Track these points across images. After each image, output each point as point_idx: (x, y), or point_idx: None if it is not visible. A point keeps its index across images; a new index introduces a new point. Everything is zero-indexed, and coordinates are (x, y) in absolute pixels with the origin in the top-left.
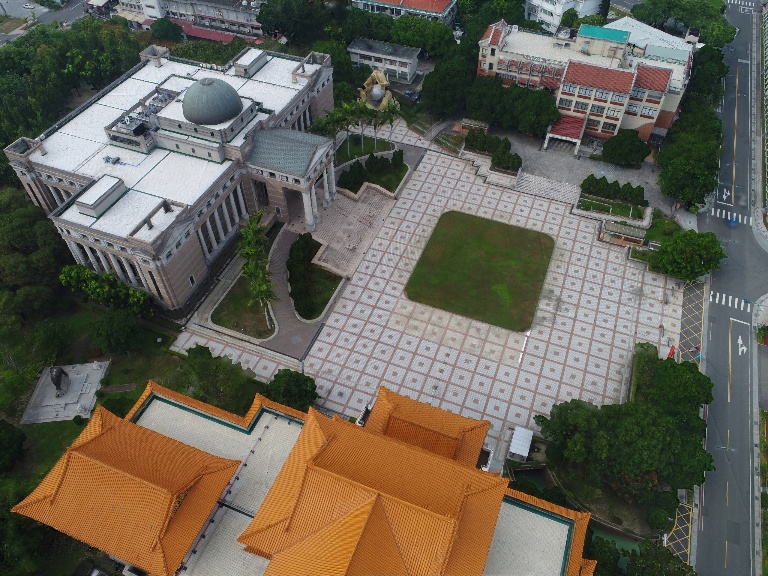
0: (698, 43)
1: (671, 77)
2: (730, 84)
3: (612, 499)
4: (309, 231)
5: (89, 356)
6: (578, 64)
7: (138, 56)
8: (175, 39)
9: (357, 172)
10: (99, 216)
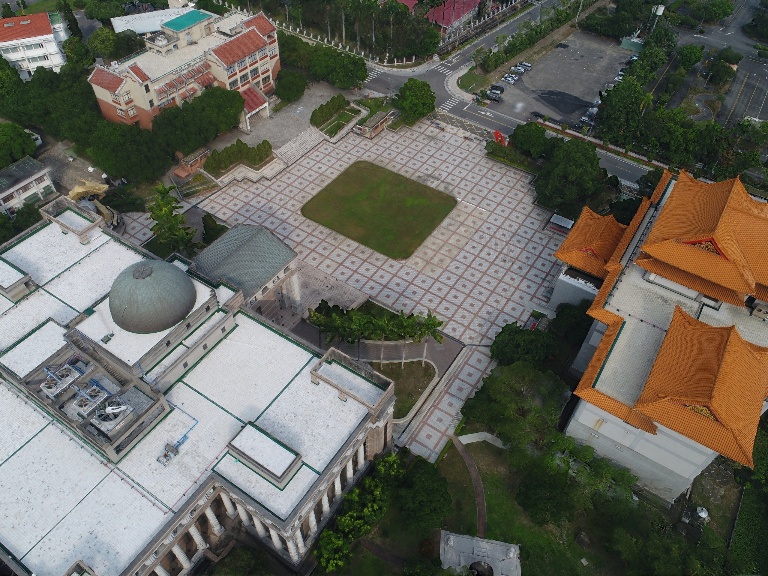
0: None
1: None
2: None
3: (594, 199)
4: (300, 311)
5: None
6: (218, 48)
7: None
8: None
9: None
10: None
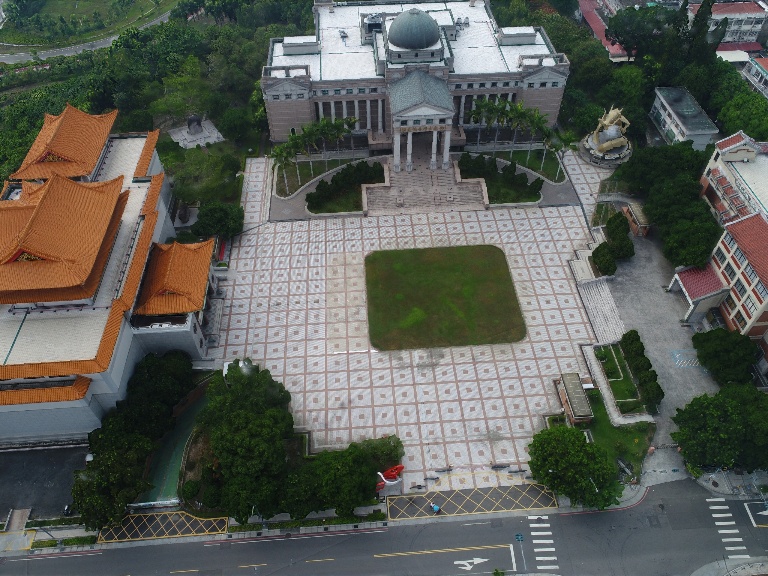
0: None
1: None
2: None
3: None
4: None
5: None
6: (763, 222)
7: (510, 4)
8: (563, 11)
9: (480, 163)
10: (286, 55)
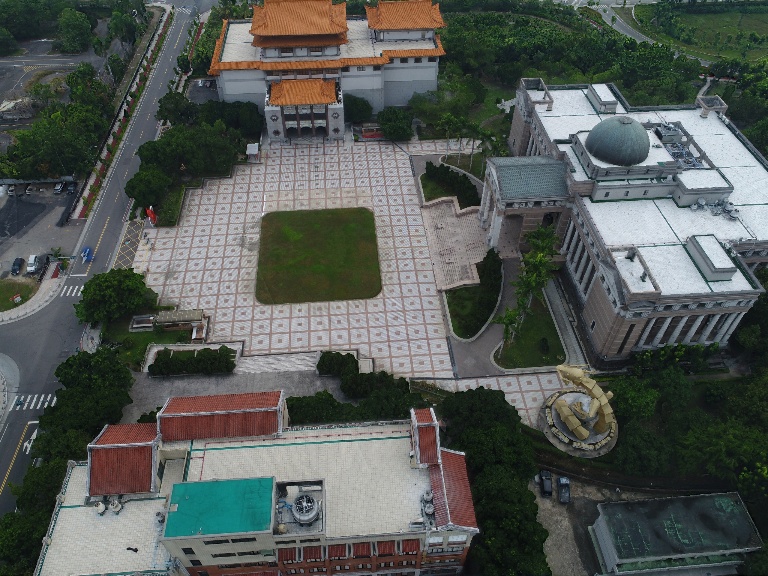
0: None
1: None
2: None
3: None
4: None
5: None
6: None
7: None
8: None
9: None
10: None
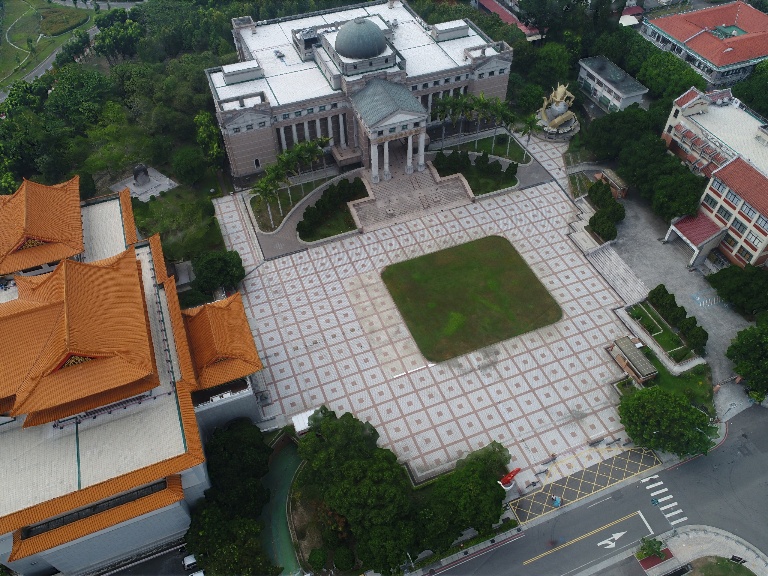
0: None
1: None
2: None
3: None
4: (372, 181)
5: (173, 175)
6: (745, 164)
7: (414, 1)
8: (462, 0)
9: (455, 159)
10: (229, 84)
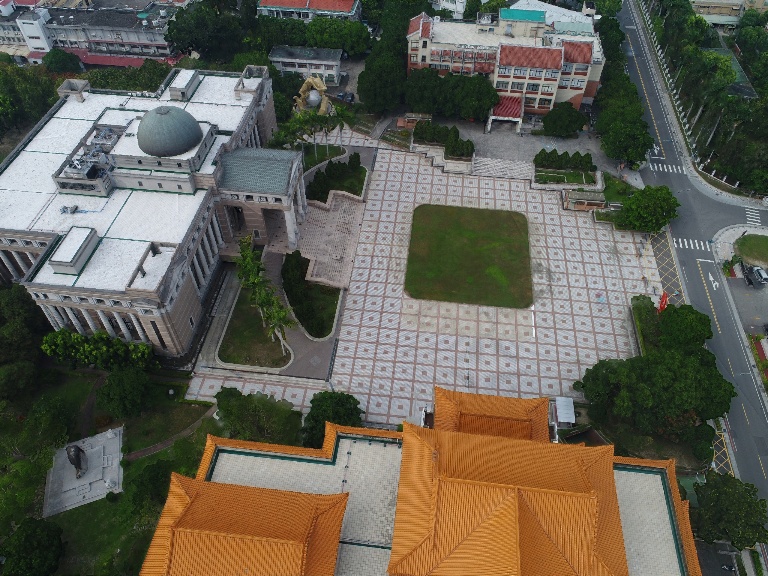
0: (595, 15)
1: (592, 49)
2: (626, 49)
3: (656, 443)
4: (292, 249)
5: (98, 426)
6: (509, 47)
7: None
8: (74, 70)
9: (322, 181)
10: (79, 273)
